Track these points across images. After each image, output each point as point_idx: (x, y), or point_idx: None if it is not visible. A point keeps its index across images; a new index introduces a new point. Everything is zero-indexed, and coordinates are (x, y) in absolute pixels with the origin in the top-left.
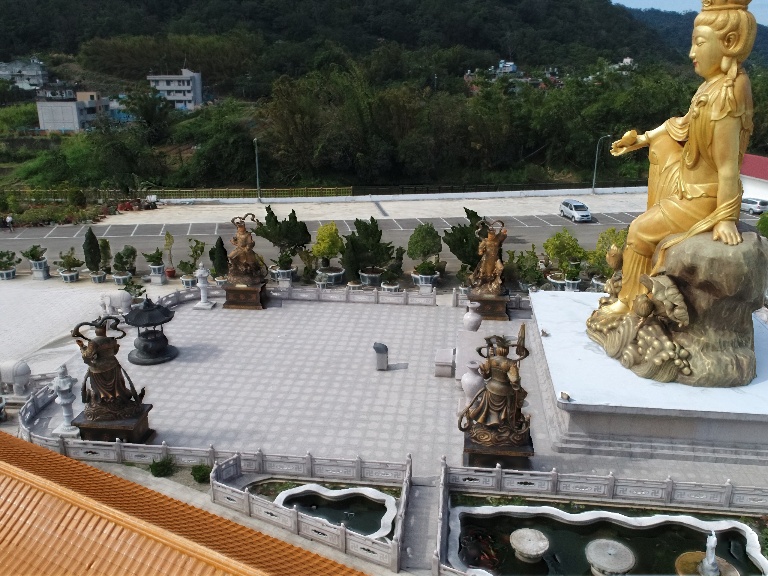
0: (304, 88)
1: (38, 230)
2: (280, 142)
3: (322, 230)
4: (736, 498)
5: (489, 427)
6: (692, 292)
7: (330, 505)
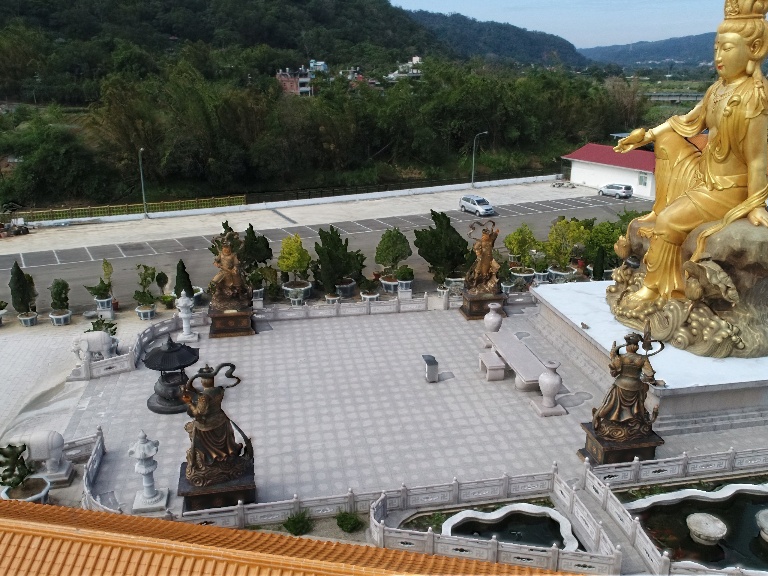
0: (143, 91)
1: None
2: (119, 150)
3: (288, 243)
4: None
5: (620, 423)
6: (736, 274)
7: (490, 529)
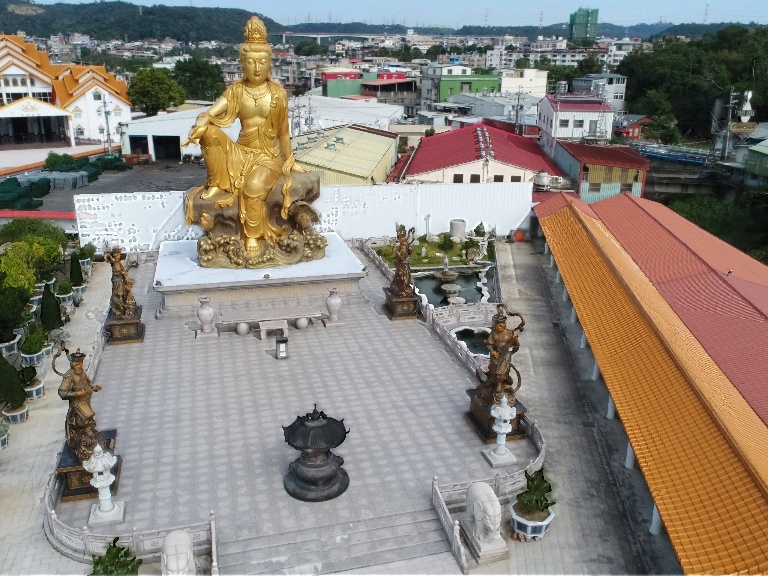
0: None
1: None
2: None
3: None
4: None
5: None
6: None
7: None
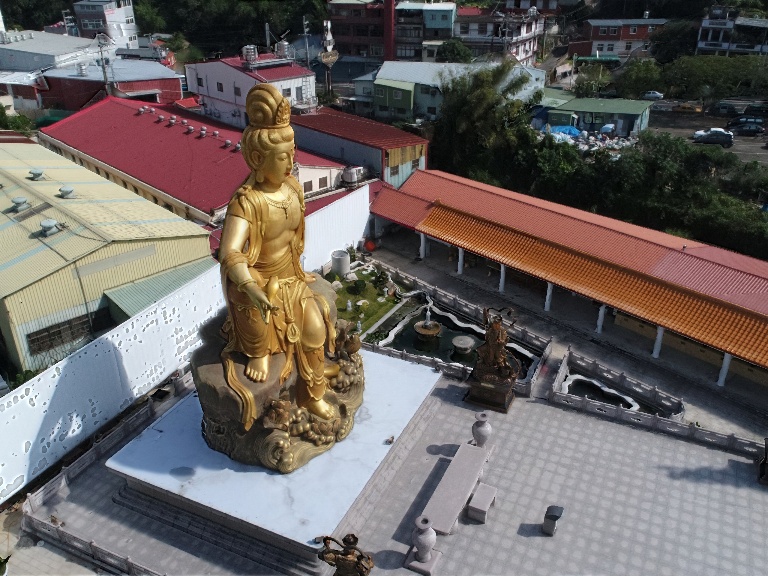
0: None
1: None
2: None
3: None
4: None
5: None
6: None
7: None
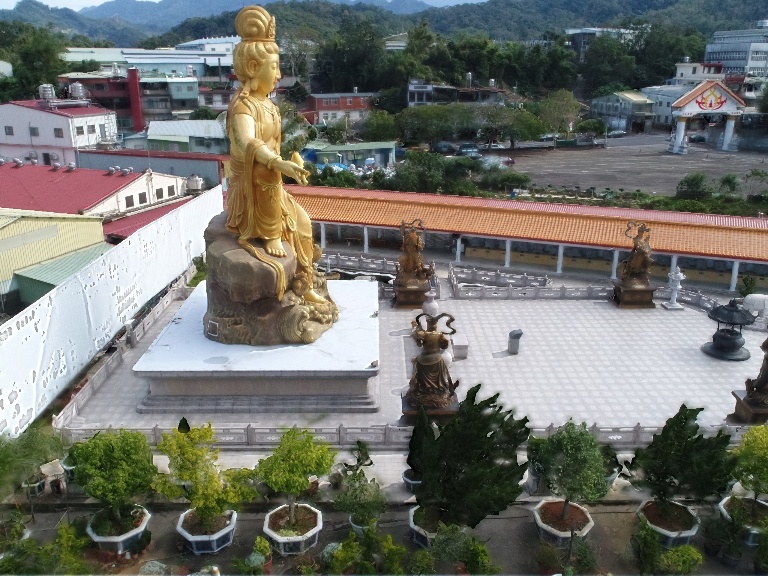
0: None
1: None
2: None
3: None
4: None
5: None
6: None
7: None
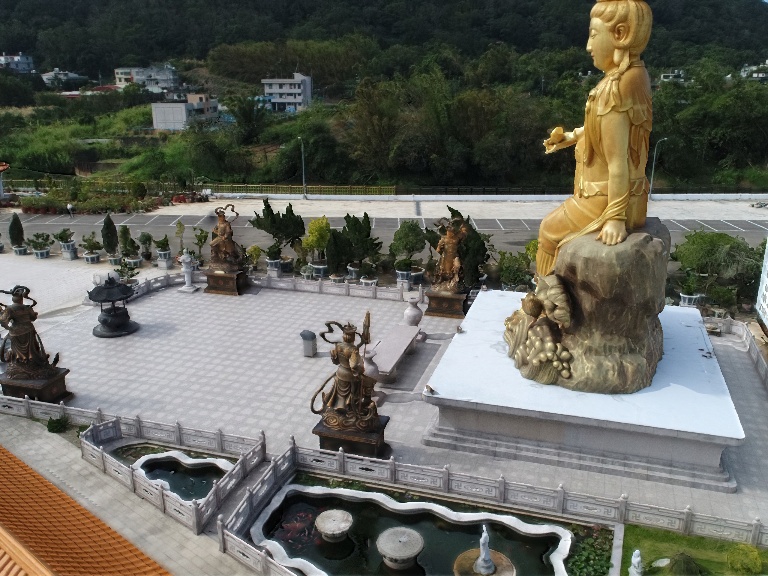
0: (383, 90)
1: (94, 217)
2: (358, 143)
3: (313, 224)
4: (569, 504)
5: (339, 412)
6: (578, 293)
7: (187, 472)
